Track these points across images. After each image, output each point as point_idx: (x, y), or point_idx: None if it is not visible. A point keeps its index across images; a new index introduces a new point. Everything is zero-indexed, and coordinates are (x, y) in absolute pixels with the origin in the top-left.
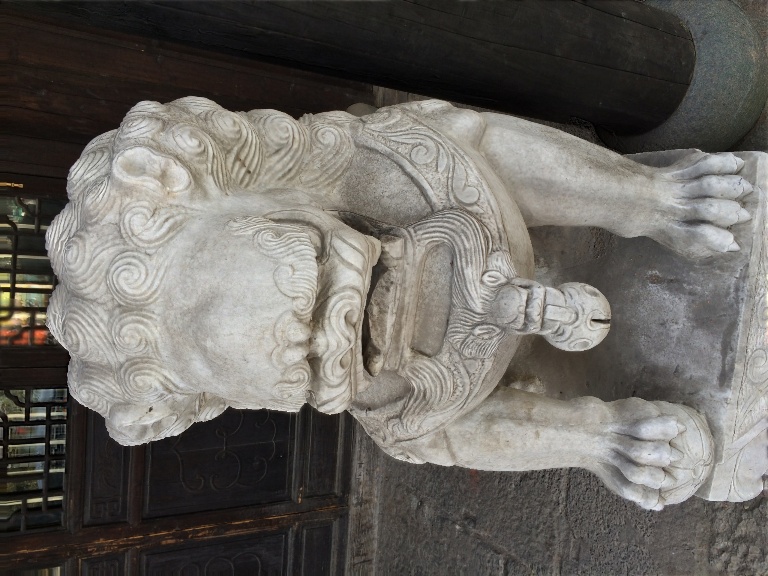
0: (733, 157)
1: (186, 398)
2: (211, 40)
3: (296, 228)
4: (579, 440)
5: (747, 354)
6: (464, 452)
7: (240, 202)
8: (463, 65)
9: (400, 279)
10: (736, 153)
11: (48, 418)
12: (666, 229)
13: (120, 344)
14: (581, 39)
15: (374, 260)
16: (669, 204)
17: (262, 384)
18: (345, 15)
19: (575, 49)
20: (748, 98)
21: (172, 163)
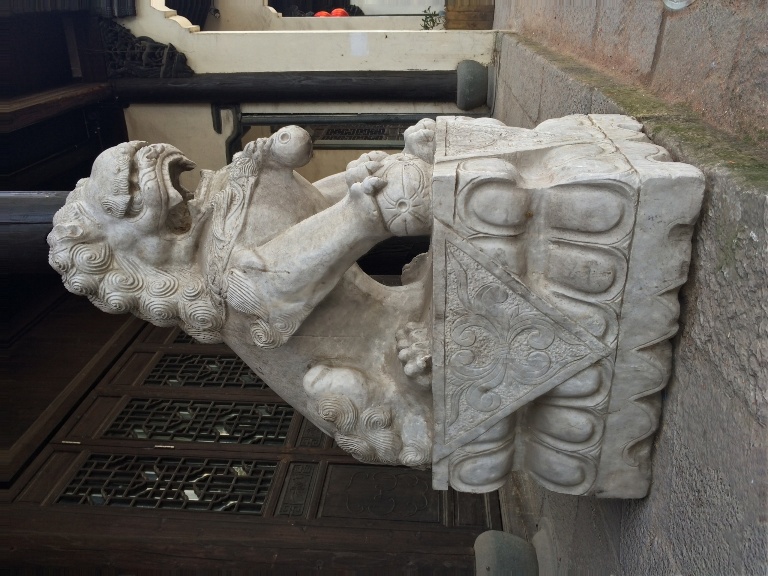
0: None
1: (91, 227)
2: None
3: None
4: None
5: None
6: (267, 253)
7: None
8: None
9: None
10: None
11: None
12: None
13: (67, 197)
14: None
15: None
16: None
17: (108, 167)
18: None
19: None
20: None
21: None
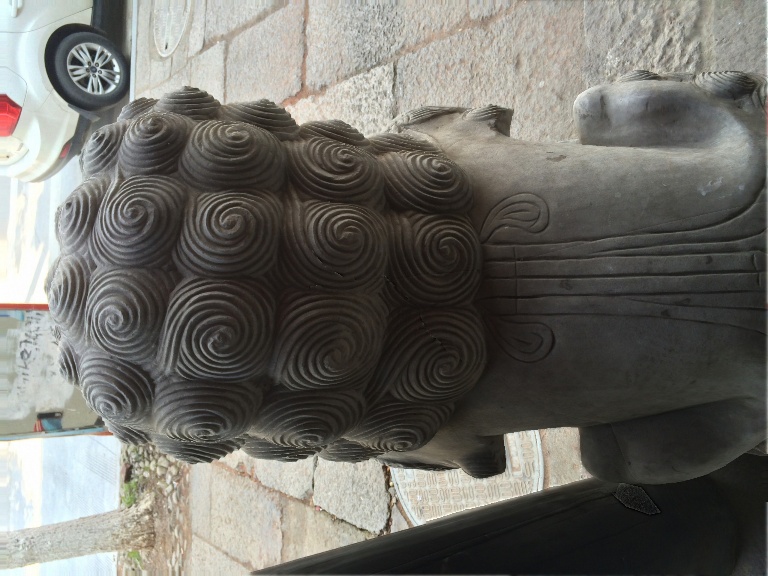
0: None
1: None
2: None
3: None
4: None
5: None
6: None
7: None
8: None
9: None
10: None
11: None
12: None
13: None
14: None
15: None
16: None
17: None
18: None
19: None
20: None
21: None
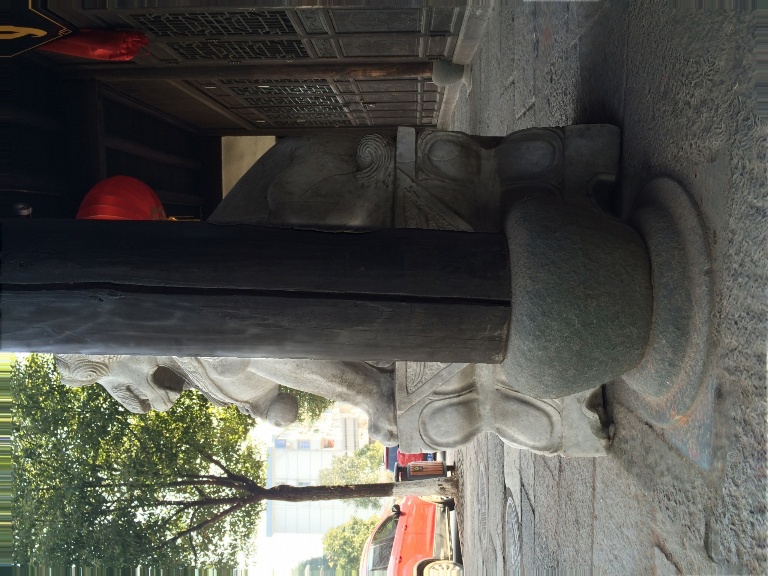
0: None
1: None
2: None
3: (135, 404)
4: None
5: None
6: None
7: (115, 378)
8: None
9: None
10: (399, 438)
11: None
12: None
13: None
14: None
15: None
16: None
17: None
18: None
19: None
20: None
21: None
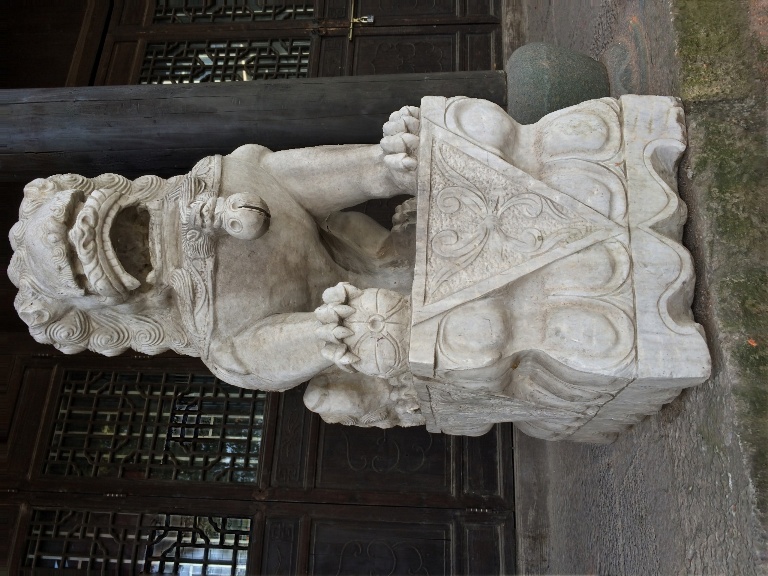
0: (405, 107)
1: (55, 303)
2: (156, 165)
3: None
4: (307, 327)
5: (430, 234)
6: (246, 357)
7: None
8: (297, 138)
9: (158, 221)
10: None
11: (236, 544)
12: (387, 175)
13: None
14: (382, 100)
15: (123, 203)
16: (378, 155)
17: (46, 261)
18: (209, 128)
19: (378, 107)
20: (553, 94)
21: (48, 181)
